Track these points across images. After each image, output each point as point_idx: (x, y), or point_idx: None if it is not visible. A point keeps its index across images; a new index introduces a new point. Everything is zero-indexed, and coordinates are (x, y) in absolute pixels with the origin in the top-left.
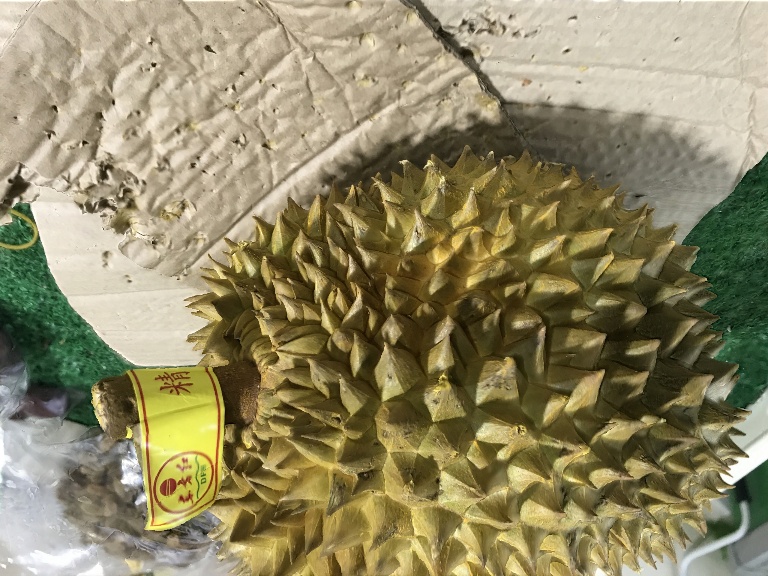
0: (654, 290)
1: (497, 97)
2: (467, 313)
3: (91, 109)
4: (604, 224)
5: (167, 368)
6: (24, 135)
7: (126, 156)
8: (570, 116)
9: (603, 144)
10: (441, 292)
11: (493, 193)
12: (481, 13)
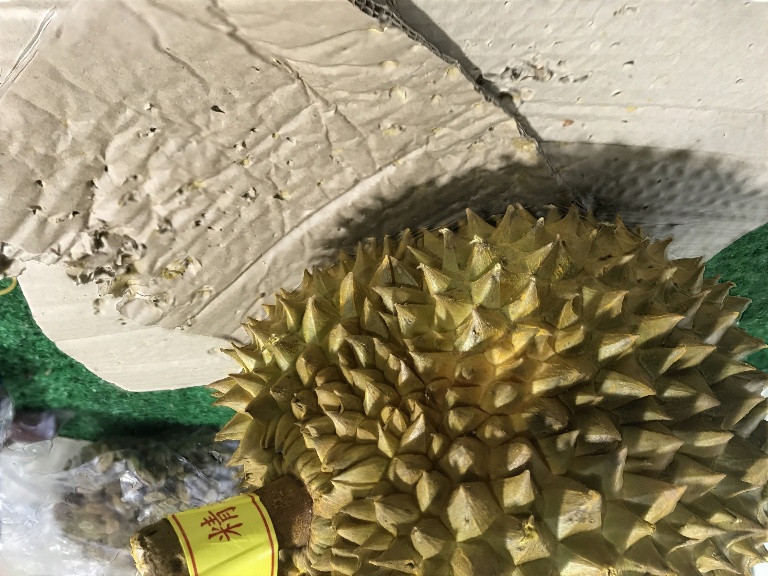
0: (718, 367)
1: (535, 138)
2: (538, 429)
3: (81, 179)
4: (665, 296)
5: (211, 505)
6: (5, 214)
7: (123, 222)
8: (611, 153)
9: (643, 179)
10: (508, 405)
11: (550, 274)
12: (528, 60)
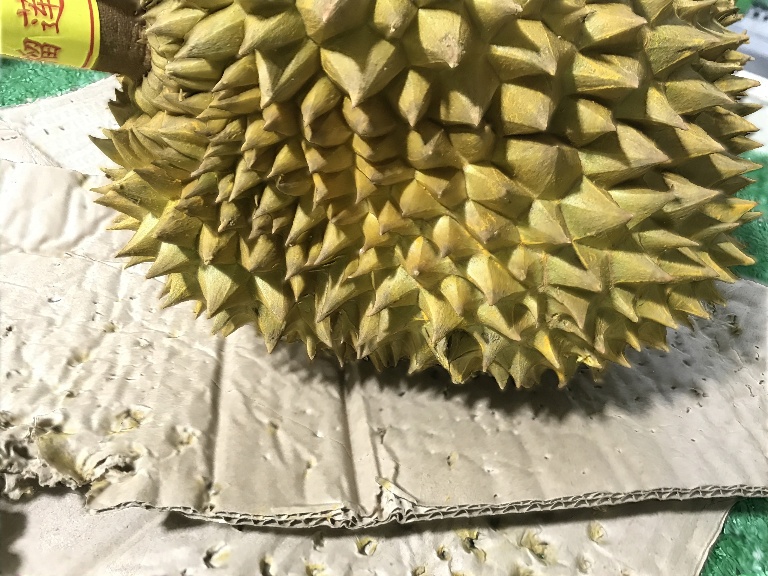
0: None
1: None
2: None
3: None
4: None
5: None
6: None
7: (25, 404)
8: None
9: None
10: None
11: None
12: None
